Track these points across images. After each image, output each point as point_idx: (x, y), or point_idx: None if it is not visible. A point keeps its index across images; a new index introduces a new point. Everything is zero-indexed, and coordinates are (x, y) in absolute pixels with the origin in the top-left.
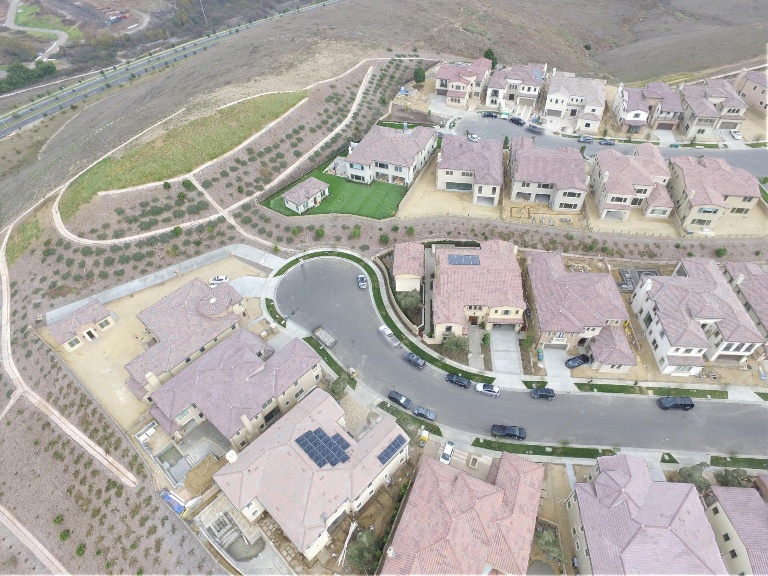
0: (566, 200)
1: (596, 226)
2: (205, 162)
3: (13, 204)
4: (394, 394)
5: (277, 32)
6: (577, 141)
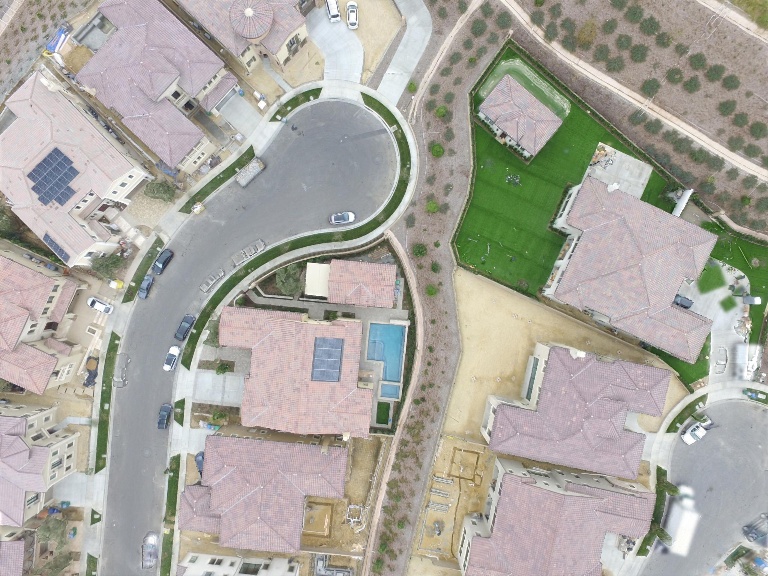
0: None
1: (426, 569)
2: None
3: None
4: (165, 255)
5: None
6: None
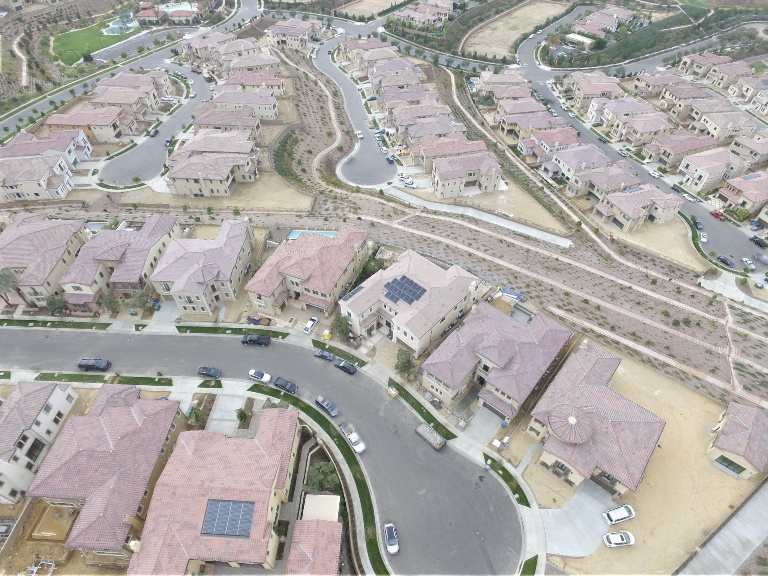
0: None
1: None
2: None
3: None
4: (351, 368)
5: None
6: None
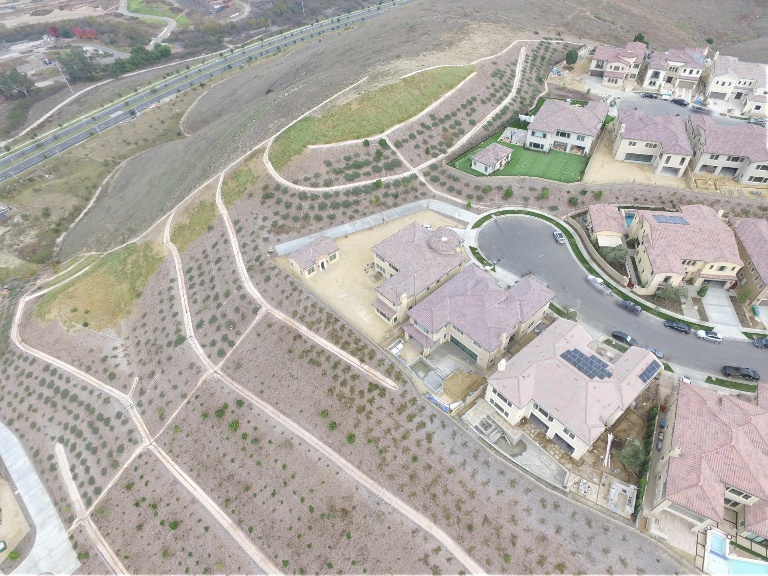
0: (757, 173)
1: None
2: (394, 125)
3: (215, 156)
4: (619, 333)
5: (428, 13)
6: (747, 122)
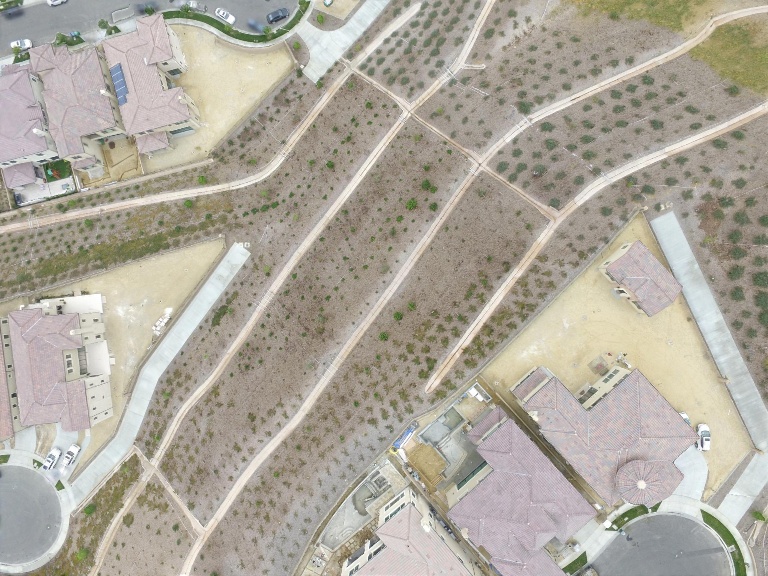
0: None
1: None
2: None
3: None
4: None
5: None
6: None
